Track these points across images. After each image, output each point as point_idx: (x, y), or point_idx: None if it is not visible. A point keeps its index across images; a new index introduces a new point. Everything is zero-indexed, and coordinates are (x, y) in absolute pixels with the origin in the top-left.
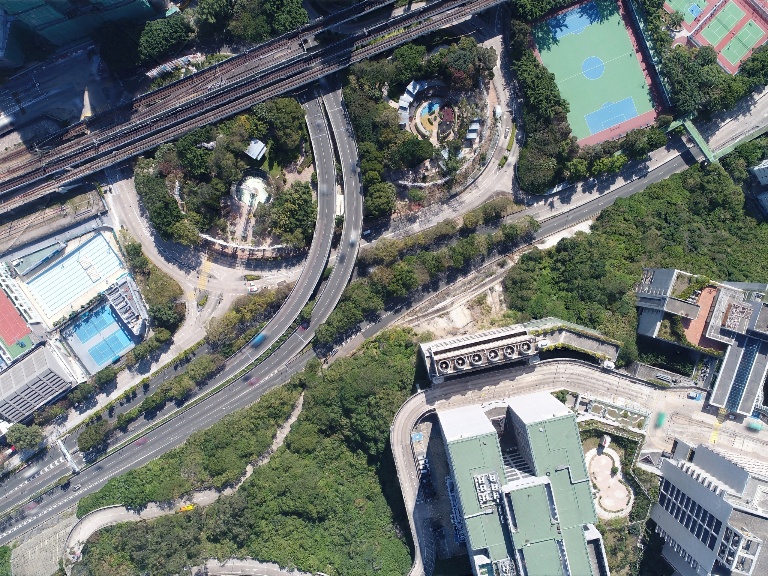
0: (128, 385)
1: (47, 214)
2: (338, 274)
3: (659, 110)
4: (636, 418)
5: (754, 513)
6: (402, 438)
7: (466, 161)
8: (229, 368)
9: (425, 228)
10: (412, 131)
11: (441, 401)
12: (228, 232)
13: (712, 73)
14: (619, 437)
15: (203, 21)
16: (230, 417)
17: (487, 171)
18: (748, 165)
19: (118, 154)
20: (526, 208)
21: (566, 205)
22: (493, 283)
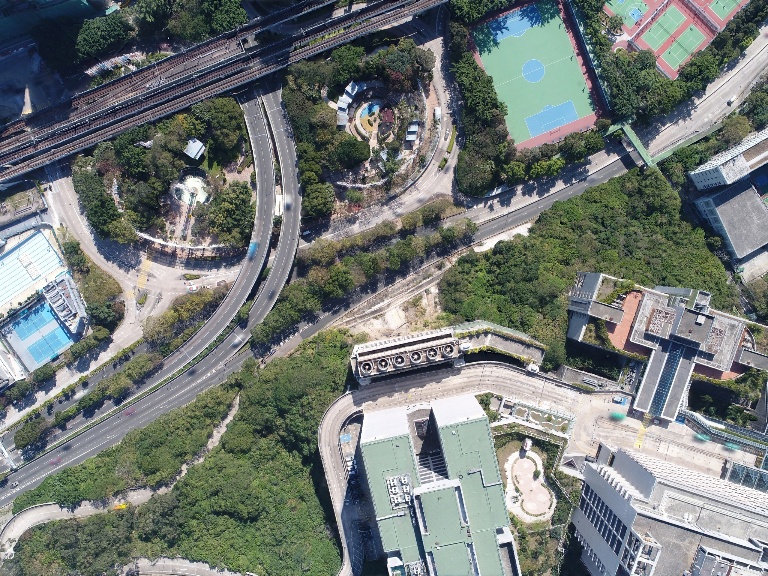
0: (67, 383)
1: None
2: (276, 274)
3: (599, 114)
4: (560, 422)
5: (658, 518)
6: (330, 439)
7: (404, 163)
8: (167, 367)
9: (365, 229)
10: (352, 132)
11: (368, 402)
12: (168, 231)
13: (649, 77)
14: (541, 441)
15: (141, 20)
16: (166, 416)
17: (427, 173)
18: (686, 170)
19: (57, 152)
20: (466, 210)
21: (506, 208)
22: (429, 285)
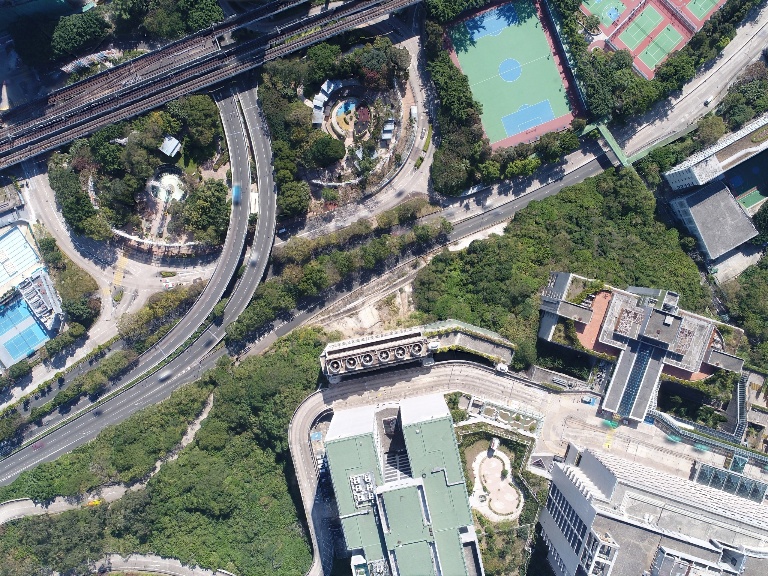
0: (43, 379)
1: None
2: (251, 272)
3: (576, 113)
4: (528, 421)
5: (618, 519)
6: (300, 437)
7: (380, 161)
8: (143, 364)
9: (340, 228)
10: (328, 130)
11: (338, 401)
12: (144, 228)
13: (624, 77)
14: (508, 440)
15: (117, 17)
16: (141, 413)
17: (403, 172)
18: (661, 170)
19: (33, 148)
20: (442, 209)
21: (482, 207)
22: (404, 284)
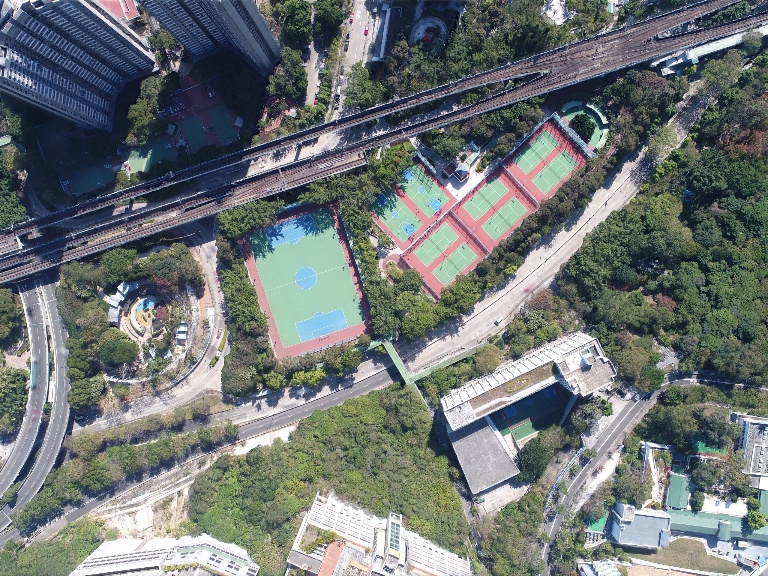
0: None
1: None
2: (45, 459)
3: (368, 324)
4: None
5: None
6: None
7: (170, 363)
8: None
9: (136, 418)
10: (127, 326)
11: None
12: None
13: (404, 303)
14: None
15: None
16: None
17: (199, 368)
18: (441, 392)
19: None
20: (234, 408)
21: (273, 408)
22: (184, 485)
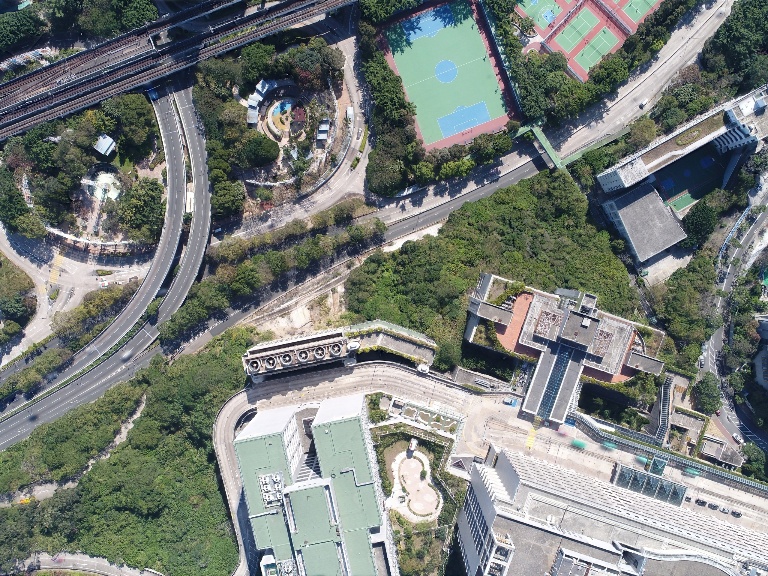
0: None
1: None
2: (186, 271)
3: (512, 115)
4: (449, 422)
5: (518, 520)
6: (225, 436)
7: (314, 161)
8: (78, 362)
9: (277, 227)
10: (264, 130)
11: (262, 400)
12: (80, 227)
13: (556, 79)
14: (426, 441)
15: (51, 15)
16: (74, 411)
17: (339, 172)
18: (594, 172)
19: None
20: (377, 210)
21: (417, 208)
22: (337, 284)
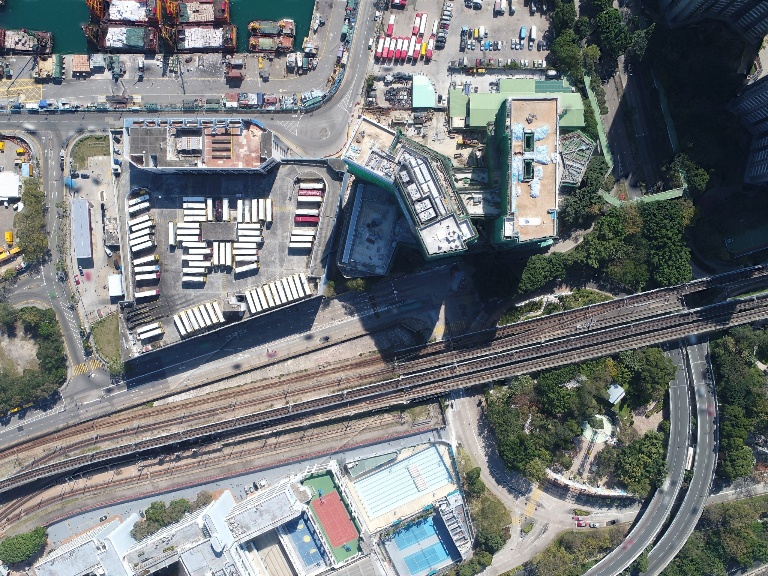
0: None
1: (385, 419)
2: (677, 528)
3: None
4: None
5: None
6: None
7: None
8: None
9: None
10: None
11: None
12: None
13: None
14: None
15: (585, 263)
16: None
17: None
18: None
19: (473, 377)
20: None
21: None
22: None
